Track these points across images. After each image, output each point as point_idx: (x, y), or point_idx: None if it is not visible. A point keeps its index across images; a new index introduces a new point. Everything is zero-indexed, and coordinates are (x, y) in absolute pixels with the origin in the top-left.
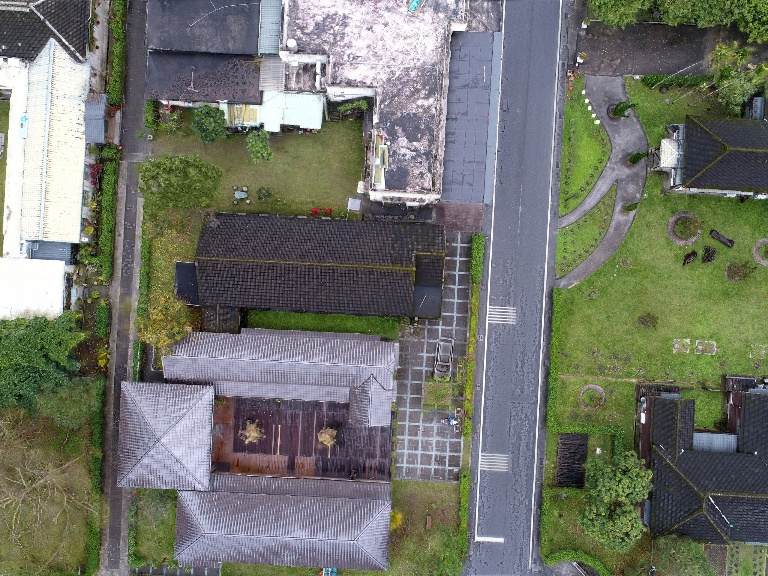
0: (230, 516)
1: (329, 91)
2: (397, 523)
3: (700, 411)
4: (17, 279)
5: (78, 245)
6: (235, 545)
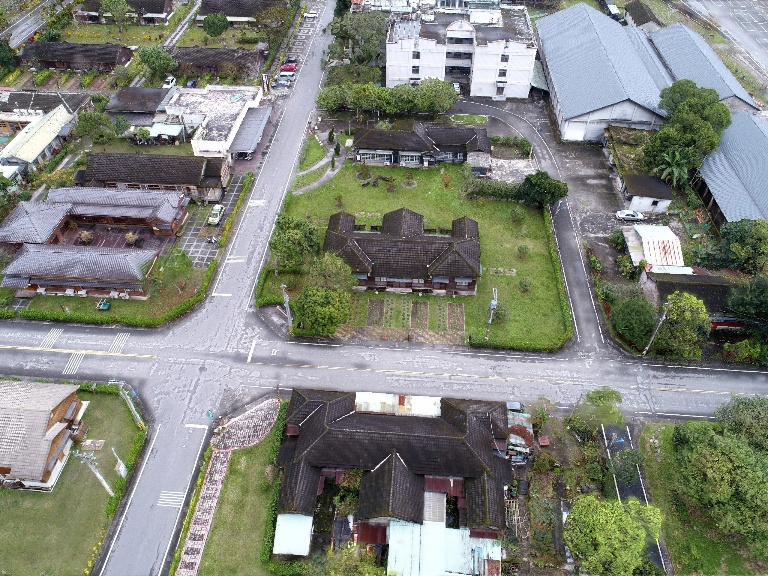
0: None
1: (185, 120)
2: (160, 276)
3: None
4: None
5: (29, 172)
6: (46, 260)
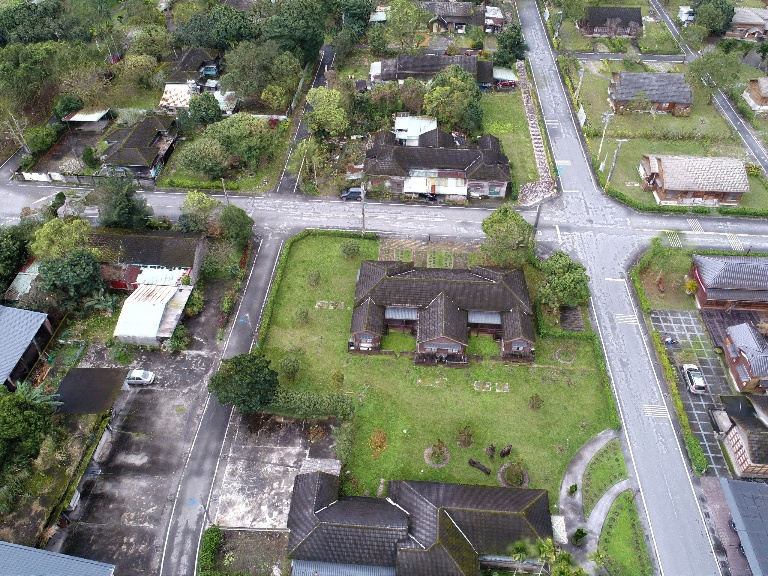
0: None
1: None
2: None
3: (482, 346)
4: None
5: None
6: None
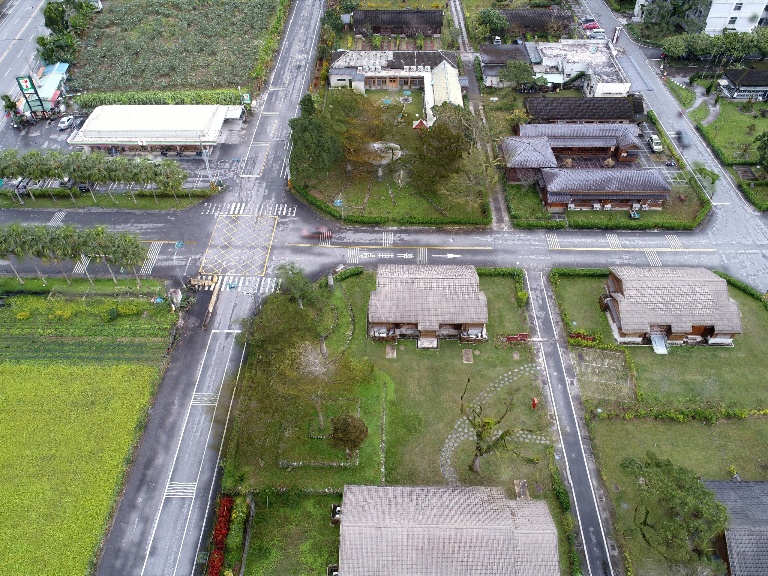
0: None
1: (566, 69)
2: None
3: None
4: None
5: None
6: (583, 178)
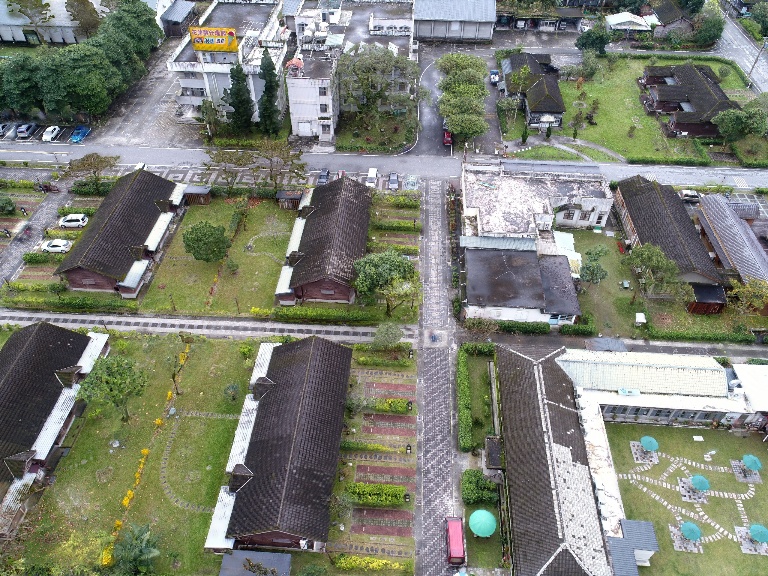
0: None
1: None
2: None
3: None
4: (765, 396)
5: None
6: None
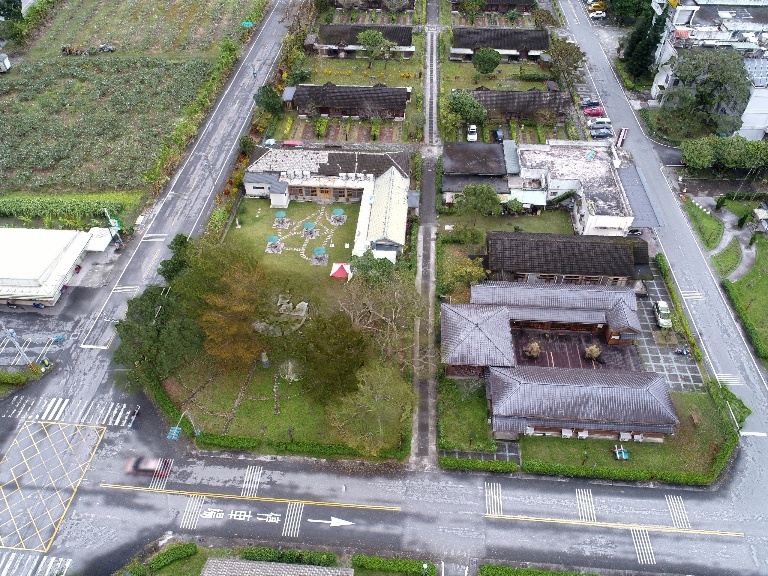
0: (538, 377)
1: (550, 186)
2: None
3: None
4: None
5: None
6: (547, 396)
